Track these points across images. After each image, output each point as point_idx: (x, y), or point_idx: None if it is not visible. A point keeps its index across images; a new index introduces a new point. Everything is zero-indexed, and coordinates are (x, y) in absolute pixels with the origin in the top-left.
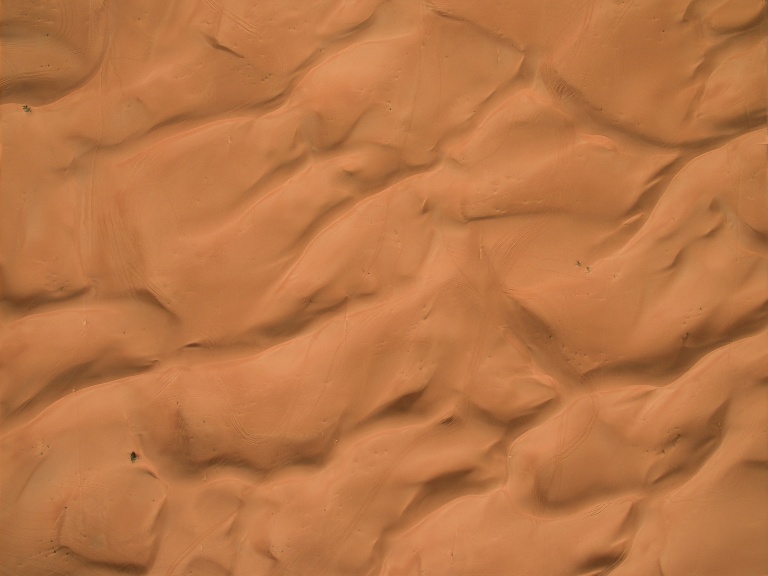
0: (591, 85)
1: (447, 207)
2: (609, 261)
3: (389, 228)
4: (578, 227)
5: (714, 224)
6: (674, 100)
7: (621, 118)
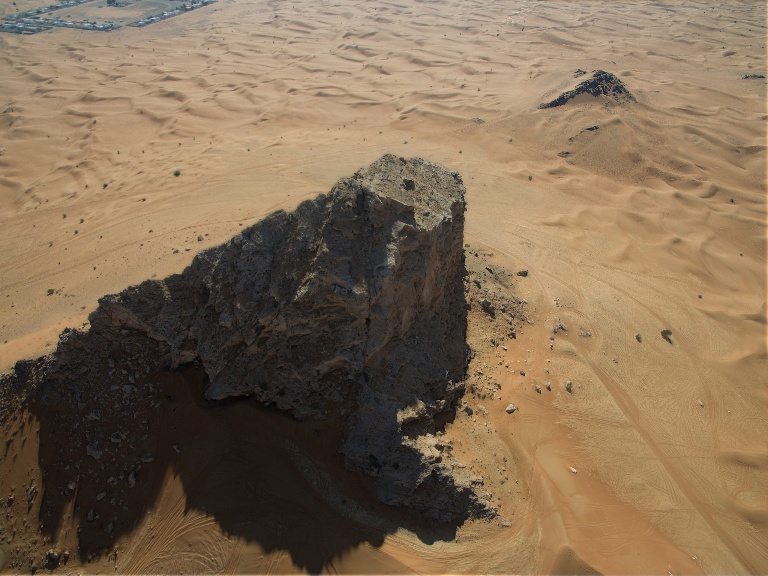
0: (566, 2)
1: None
2: None
3: None
4: None
5: None
6: None
7: None
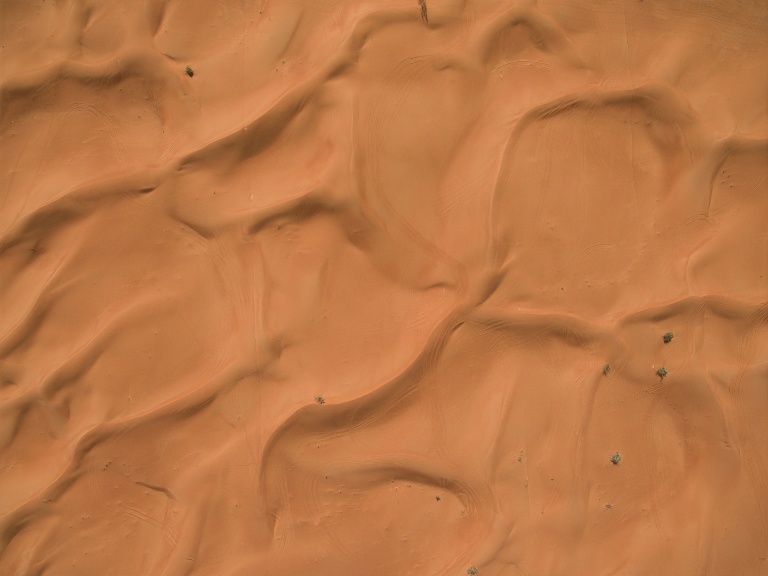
0: None
1: None
2: None
3: None
4: None
5: None
6: None
7: None
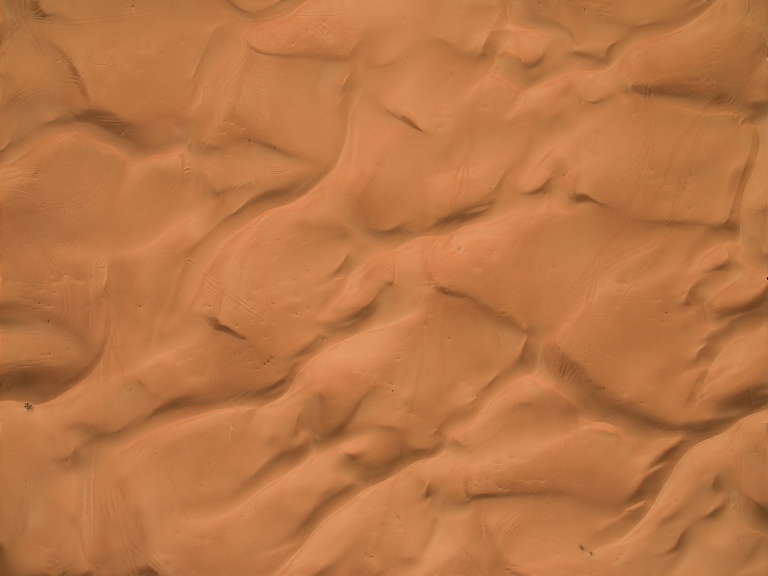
0: (594, 362)
1: (450, 489)
2: (612, 547)
3: (392, 513)
4: (581, 511)
5: (717, 504)
6: (677, 381)
7: (624, 397)
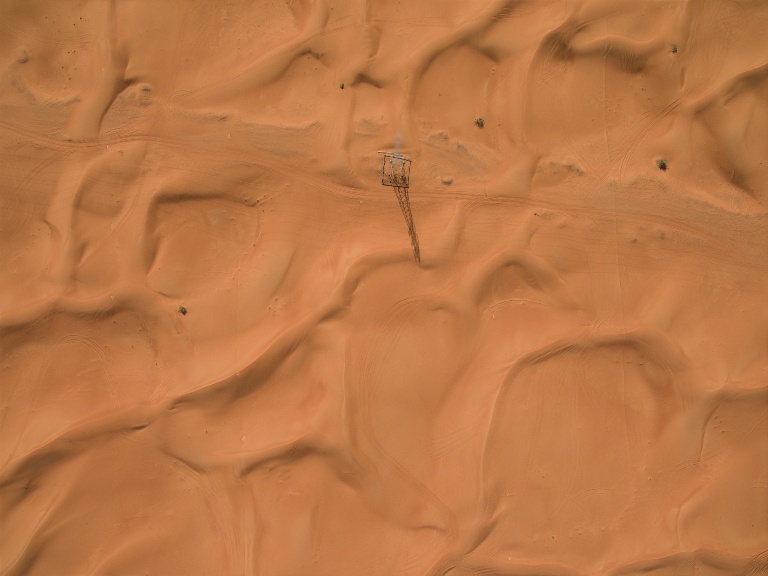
0: None
1: None
2: None
3: None
4: None
5: None
6: None
7: None
